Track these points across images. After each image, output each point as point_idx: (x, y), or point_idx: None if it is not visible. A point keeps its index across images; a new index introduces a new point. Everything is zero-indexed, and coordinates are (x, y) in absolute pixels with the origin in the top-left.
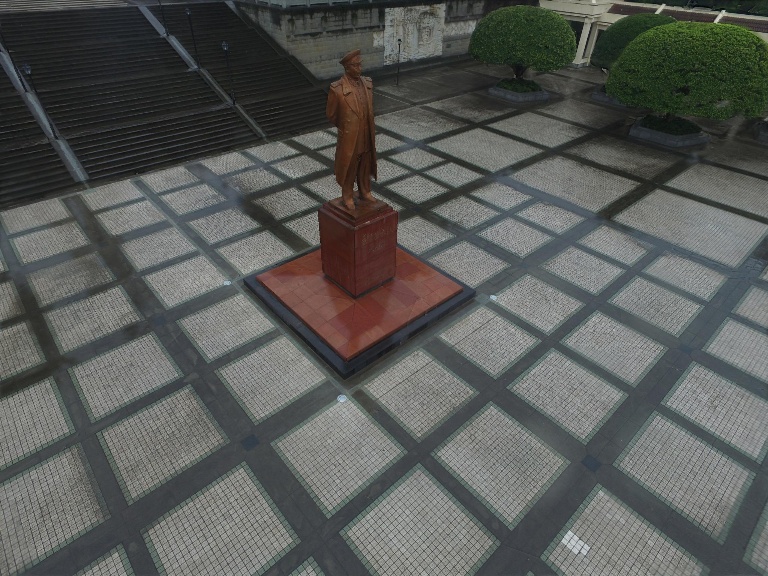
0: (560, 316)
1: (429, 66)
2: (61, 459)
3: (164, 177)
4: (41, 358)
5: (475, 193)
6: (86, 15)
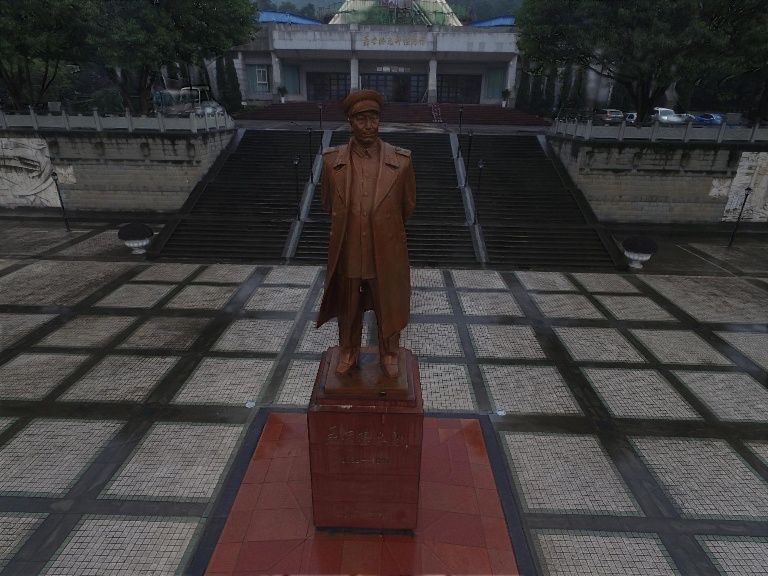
0: None
1: None
2: None
3: None
4: (44, 395)
5: (760, 447)
6: (403, 137)
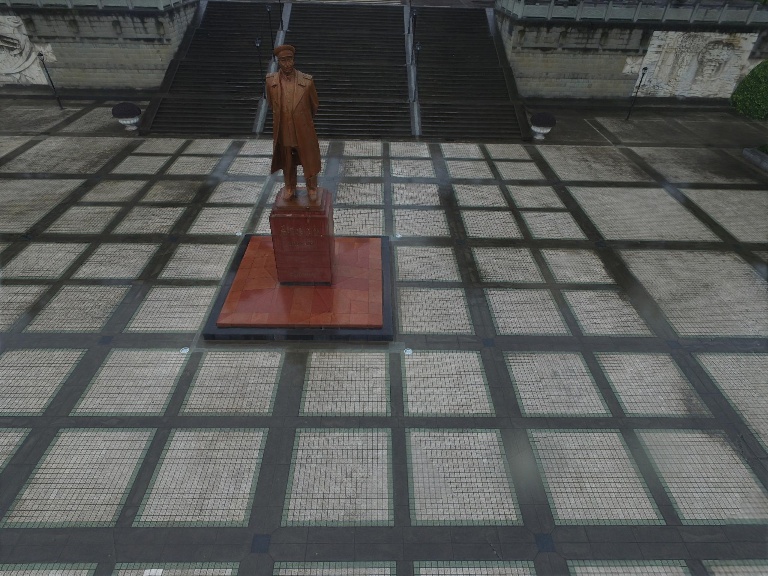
0: (447, 408)
1: (697, 107)
2: (36, 289)
3: None
4: (101, 230)
5: (547, 251)
6: (360, 10)
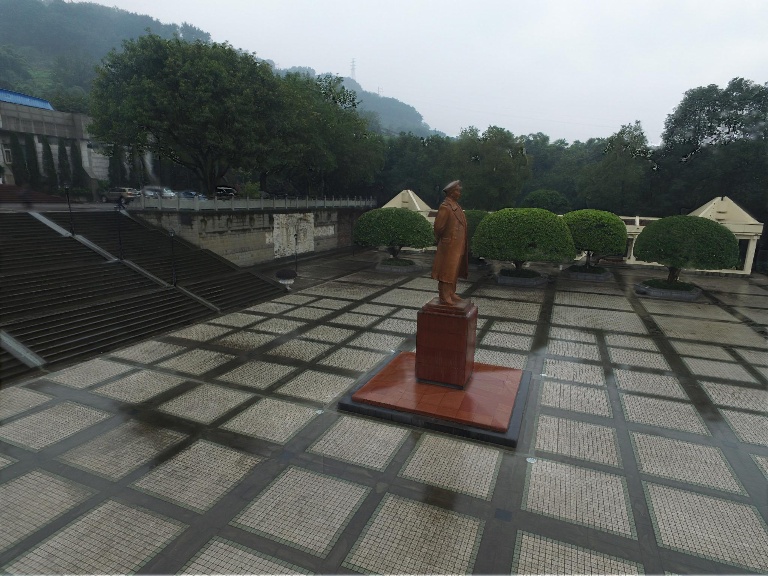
0: (598, 375)
1: (310, 258)
2: None
3: (141, 351)
4: (178, 525)
5: None
6: None
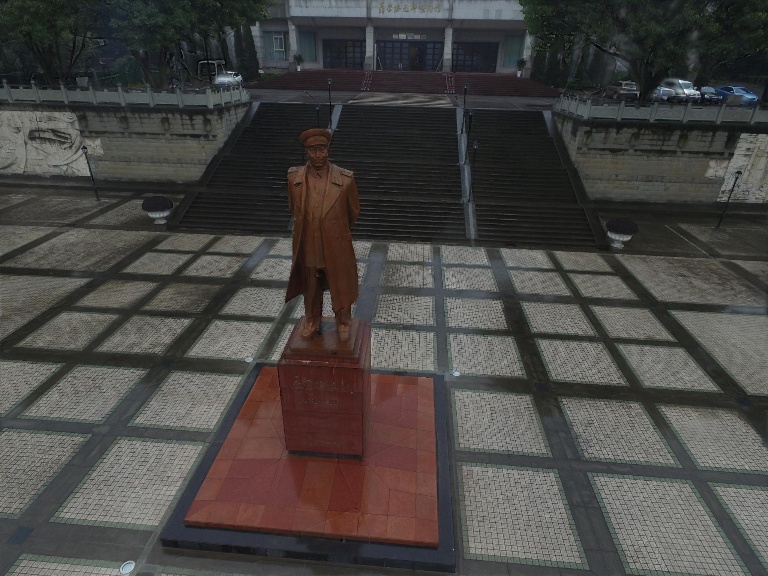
0: None
1: None
2: None
3: None
4: (84, 346)
5: (669, 410)
6: (411, 111)
